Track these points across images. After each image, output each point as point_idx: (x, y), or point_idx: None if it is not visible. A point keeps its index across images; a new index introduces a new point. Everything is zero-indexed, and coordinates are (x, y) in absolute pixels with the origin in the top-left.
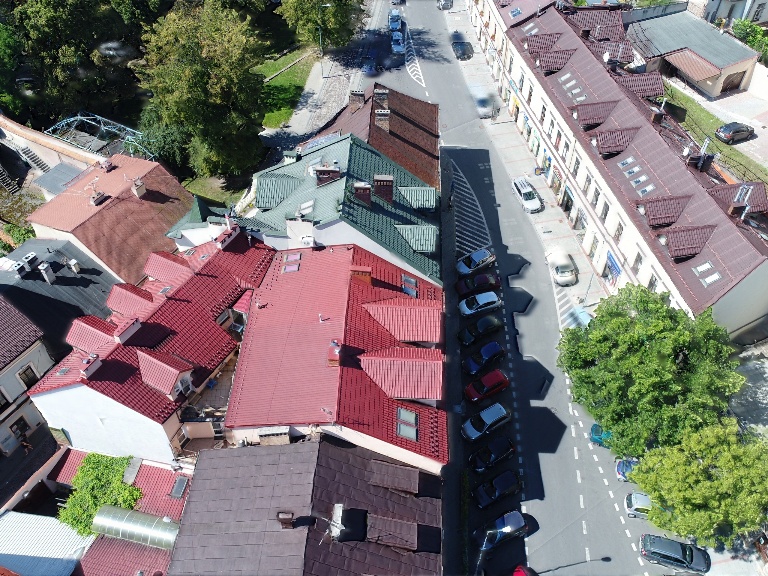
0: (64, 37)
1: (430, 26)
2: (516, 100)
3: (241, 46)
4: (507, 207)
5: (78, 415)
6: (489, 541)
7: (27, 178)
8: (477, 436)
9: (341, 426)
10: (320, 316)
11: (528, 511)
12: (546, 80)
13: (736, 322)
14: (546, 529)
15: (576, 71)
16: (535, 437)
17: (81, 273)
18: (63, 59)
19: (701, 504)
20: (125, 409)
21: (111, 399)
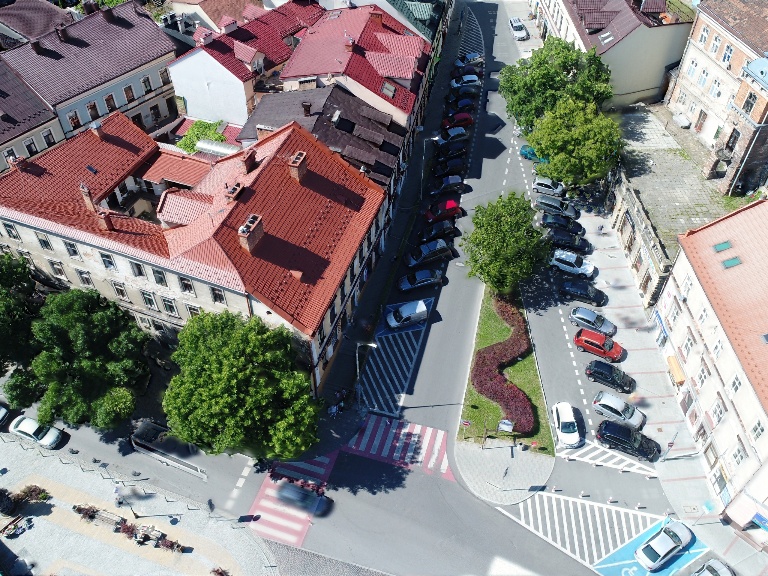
0: None
1: None
2: None
3: None
4: (502, 36)
5: (195, 82)
6: (437, 188)
7: None
8: (443, 142)
9: (347, 77)
10: (345, 31)
11: (468, 183)
12: None
13: (631, 84)
14: (477, 192)
15: None
16: (483, 151)
17: None
18: None
19: (562, 146)
20: (223, 71)
21: (216, 61)
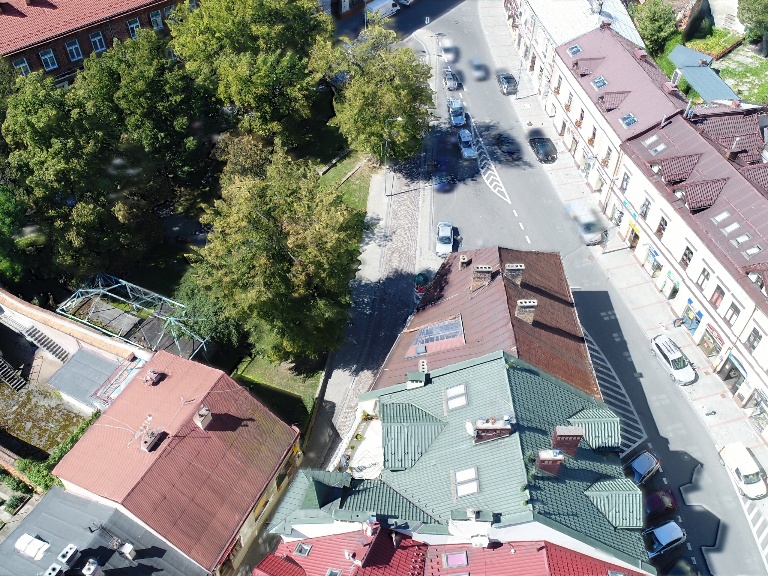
0: (78, 190)
1: (498, 118)
2: (635, 227)
3: (336, 226)
4: (651, 377)
5: None
6: None
7: (34, 364)
8: None
9: None
10: None
11: None
12: (695, 220)
13: None
14: None
15: (736, 210)
16: None
17: (137, 558)
18: (77, 217)
19: None
20: None
21: None
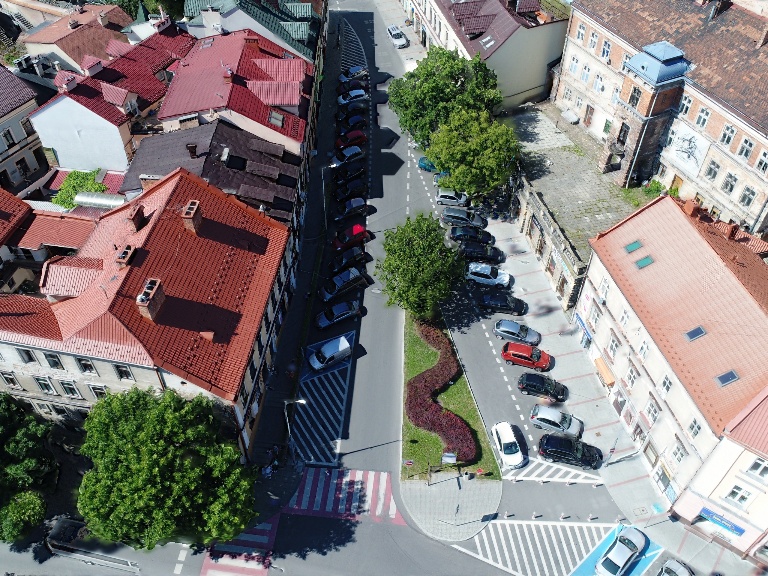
0: None
1: None
2: None
3: None
4: (382, 46)
5: (63, 131)
6: (341, 214)
7: (19, 37)
8: (340, 164)
9: (230, 111)
10: None
11: (371, 204)
12: None
13: (517, 85)
14: (382, 212)
15: None
16: (382, 167)
17: None
18: None
19: (461, 158)
20: (93, 117)
21: (84, 107)
